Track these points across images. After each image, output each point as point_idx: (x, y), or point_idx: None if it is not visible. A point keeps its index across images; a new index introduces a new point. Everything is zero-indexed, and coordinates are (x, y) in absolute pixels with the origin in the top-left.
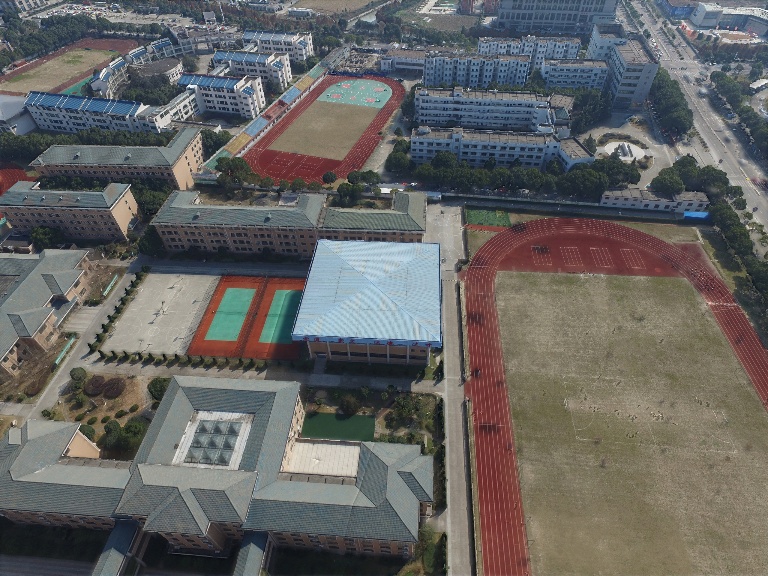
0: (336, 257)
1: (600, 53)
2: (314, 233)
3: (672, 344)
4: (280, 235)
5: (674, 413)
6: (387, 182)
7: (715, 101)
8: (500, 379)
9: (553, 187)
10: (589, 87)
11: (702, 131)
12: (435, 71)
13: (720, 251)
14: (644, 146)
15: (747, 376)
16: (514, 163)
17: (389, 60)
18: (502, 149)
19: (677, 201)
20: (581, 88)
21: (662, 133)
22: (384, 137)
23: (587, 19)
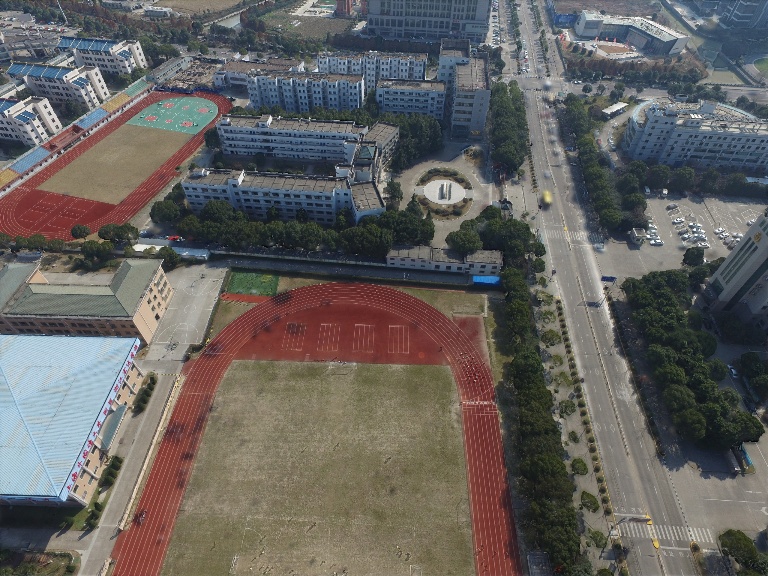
0: None
1: (443, 73)
2: (2, 319)
3: (398, 464)
4: None
5: (361, 573)
6: (156, 234)
7: (565, 128)
8: (167, 526)
9: (332, 246)
10: (429, 112)
11: (538, 166)
12: (260, 91)
13: (501, 327)
14: (467, 186)
15: (470, 511)
16: (298, 214)
17: (221, 75)
18: (286, 196)
19: (468, 263)
20: (413, 115)
21: (494, 168)
22: (181, 173)
23: (460, 27)
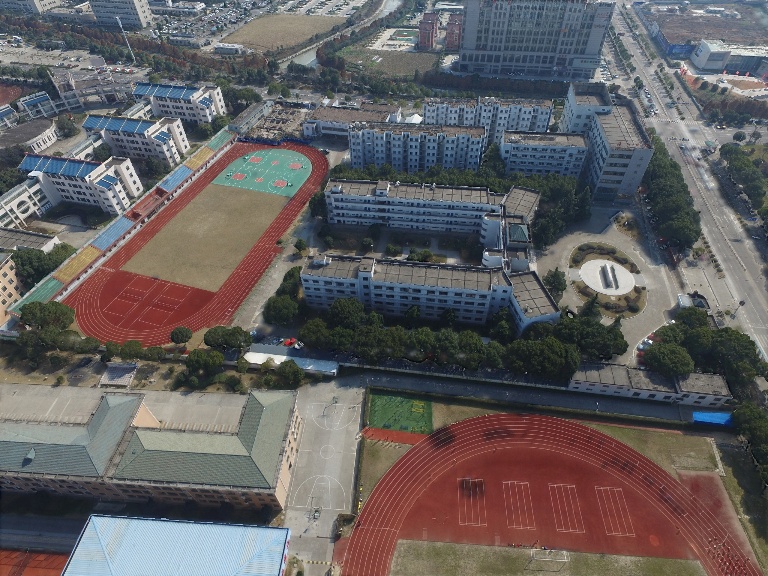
0: (103, 567)
1: (577, 123)
2: None
3: None
4: (54, 480)
5: None
6: (268, 336)
7: (727, 188)
8: None
9: (498, 364)
10: (563, 169)
11: (713, 240)
12: (364, 146)
13: (751, 494)
14: (634, 269)
15: None
16: (445, 316)
17: (312, 124)
18: (429, 293)
19: (682, 393)
20: (550, 176)
21: (659, 244)
22: (283, 249)
23: (566, 62)
